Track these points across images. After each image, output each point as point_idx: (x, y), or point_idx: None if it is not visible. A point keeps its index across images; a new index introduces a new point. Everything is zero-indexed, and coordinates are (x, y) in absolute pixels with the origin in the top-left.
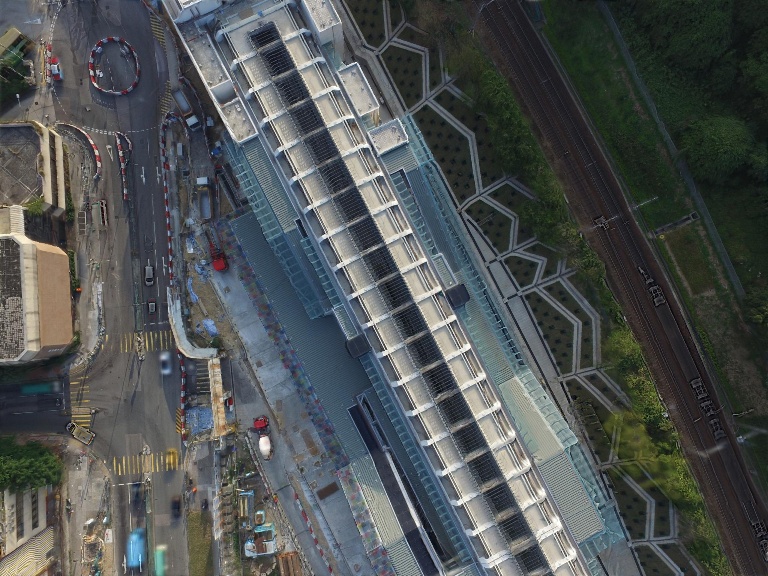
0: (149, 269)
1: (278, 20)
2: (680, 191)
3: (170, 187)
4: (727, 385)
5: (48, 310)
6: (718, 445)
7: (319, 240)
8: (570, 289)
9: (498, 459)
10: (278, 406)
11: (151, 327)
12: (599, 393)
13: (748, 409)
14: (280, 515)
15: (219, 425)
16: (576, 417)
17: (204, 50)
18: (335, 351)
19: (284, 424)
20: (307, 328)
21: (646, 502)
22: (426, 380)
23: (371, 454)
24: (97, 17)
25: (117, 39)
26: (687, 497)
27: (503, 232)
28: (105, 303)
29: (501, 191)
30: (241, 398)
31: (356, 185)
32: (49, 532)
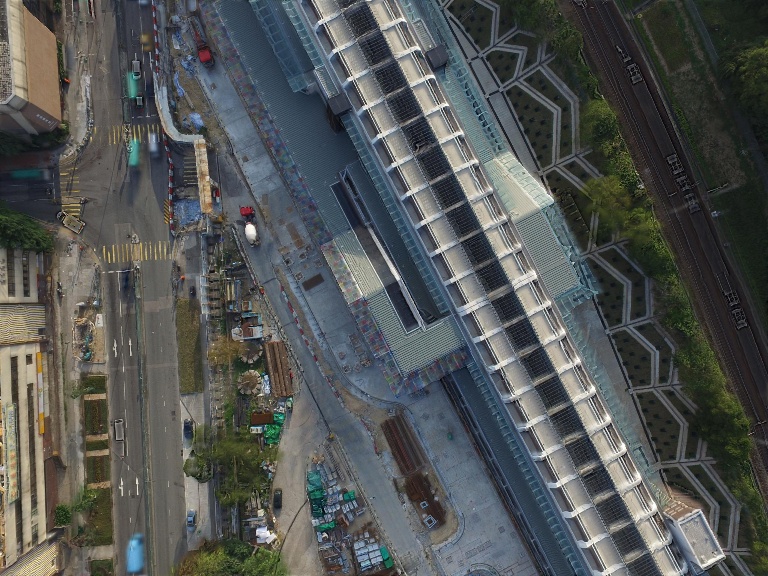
0: (136, 63)
1: None
2: None
3: None
4: (702, 161)
5: (36, 72)
6: (693, 219)
7: None
8: (550, 76)
9: (475, 209)
10: (264, 200)
11: (139, 120)
12: (578, 180)
13: (722, 184)
14: (266, 306)
15: (205, 202)
16: (556, 210)
17: None
18: (318, 131)
19: (270, 217)
20: (291, 108)
21: (623, 285)
22: (405, 132)
23: (354, 230)
24: None
25: None
26: (660, 253)
27: (485, 26)
28: (93, 96)
29: None
30: (228, 191)
31: None
32: (41, 311)
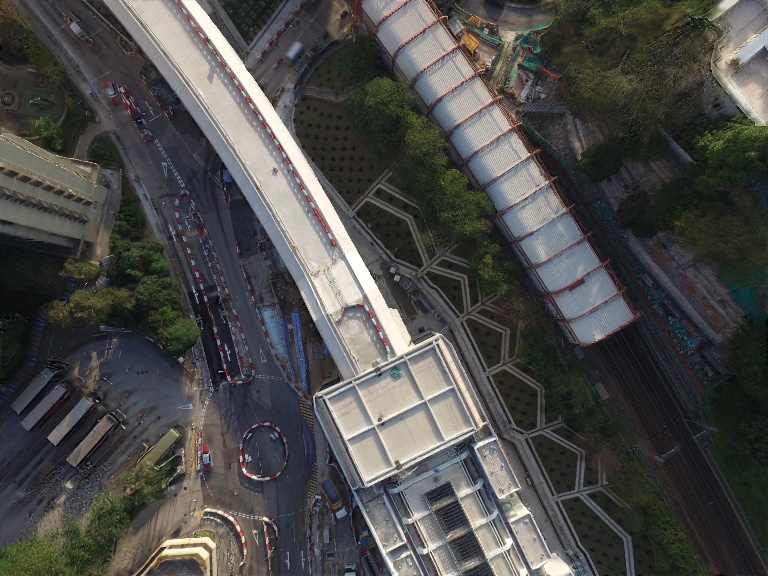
0: None
1: (453, 475)
2: None
3: (315, 573)
4: None
5: None
6: None
7: None
8: None
9: None
10: None
11: None
12: None
13: None
14: None
15: None
16: None
17: (379, 509)
18: None
19: None
20: None
21: None
22: None
23: None
24: (248, 401)
25: (267, 425)
26: None
27: None
28: None
29: None
30: None
31: None
32: None
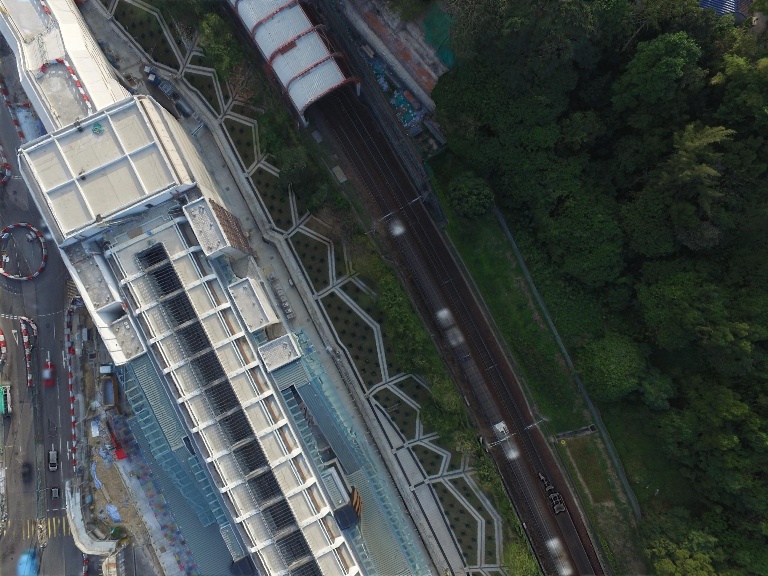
0: (53, 454)
1: (167, 238)
2: (579, 402)
3: (75, 371)
4: None
5: None
6: None
7: (205, 461)
8: (473, 487)
9: None
10: None
11: (54, 513)
12: None
13: None
14: None
15: None
16: None
17: (92, 270)
18: None
19: None
20: (203, 529)
21: None
22: None
23: None
24: (4, 202)
25: (24, 225)
26: None
27: (409, 421)
28: (8, 488)
29: (406, 383)
30: None
31: (242, 408)
32: None
